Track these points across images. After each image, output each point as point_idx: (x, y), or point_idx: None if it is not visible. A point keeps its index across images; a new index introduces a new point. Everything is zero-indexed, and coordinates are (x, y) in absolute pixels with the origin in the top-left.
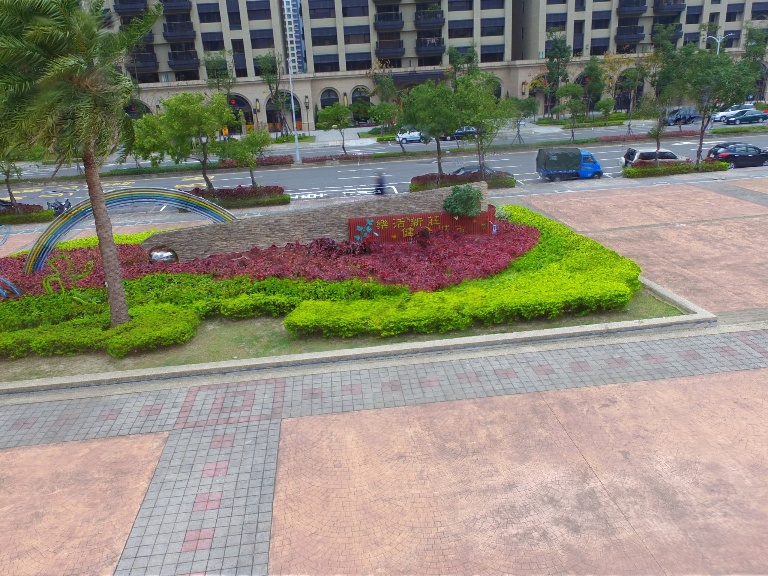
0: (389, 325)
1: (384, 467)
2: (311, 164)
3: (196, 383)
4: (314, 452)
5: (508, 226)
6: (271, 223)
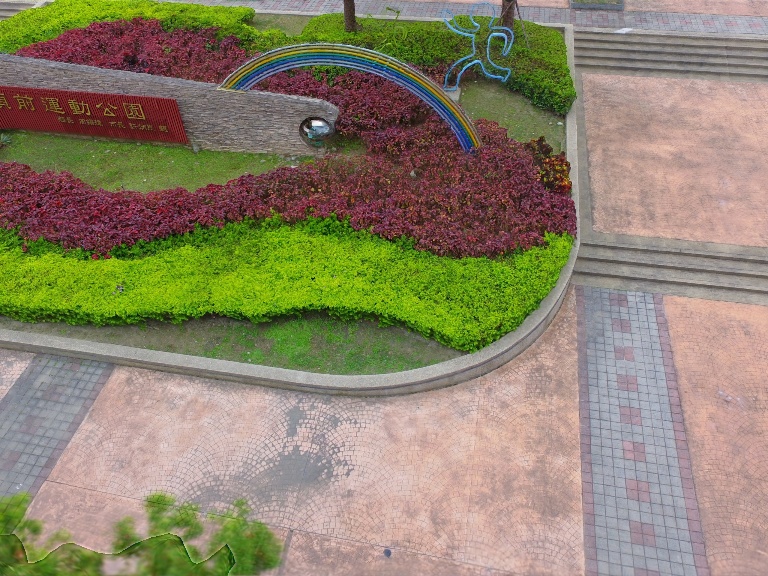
0: None
1: None
2: None
3: None
4: None
5: None
6: None
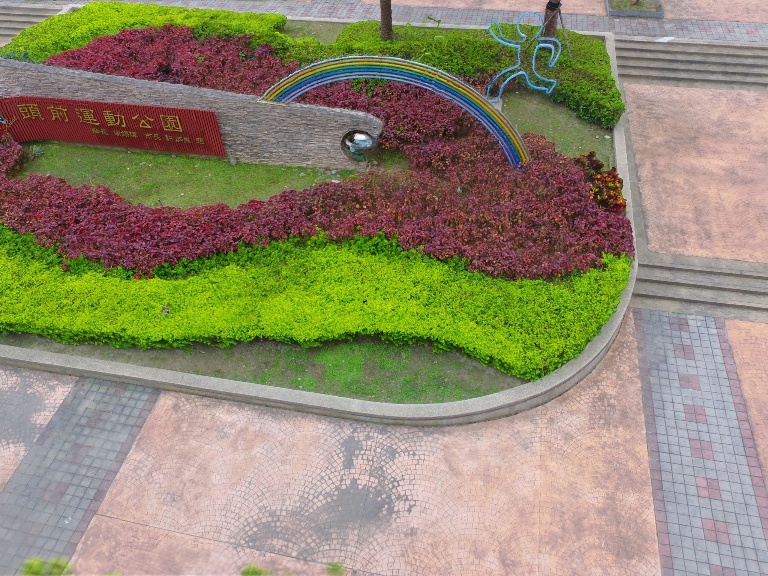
0: None
1: None
2: None
3: None
4: None
5: None
6: None
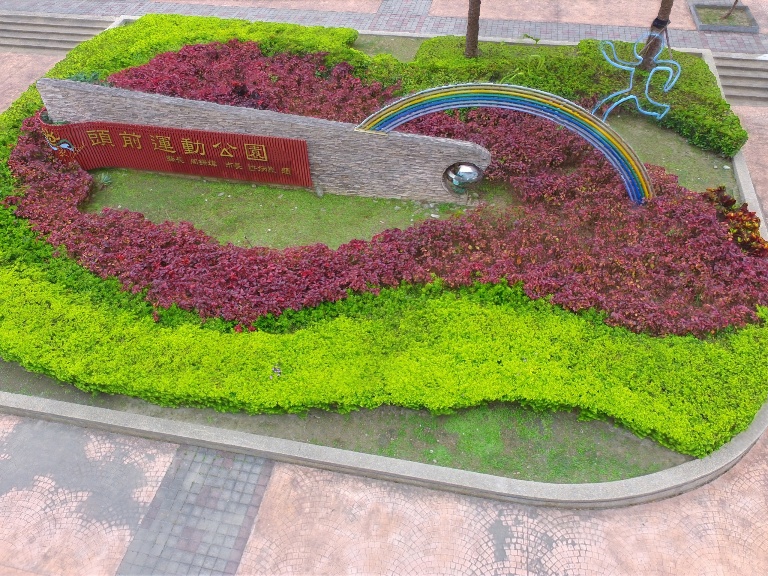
0: None
1: None
2: None
3: None
4: None
5: None
6: None
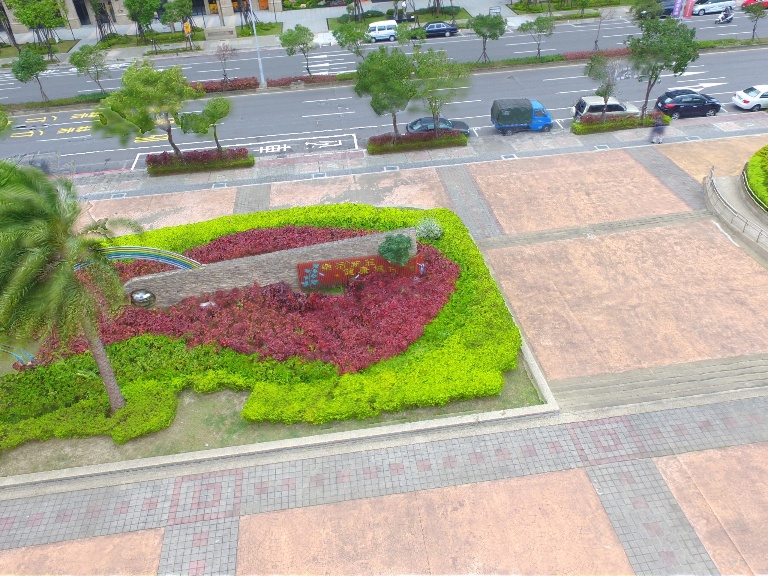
0: (319, 418)
1: (303, 569)
2: (276, 88)
3: (180, 473)
4: (260, 553)
5: (434, 264)
6: (232, 269)
